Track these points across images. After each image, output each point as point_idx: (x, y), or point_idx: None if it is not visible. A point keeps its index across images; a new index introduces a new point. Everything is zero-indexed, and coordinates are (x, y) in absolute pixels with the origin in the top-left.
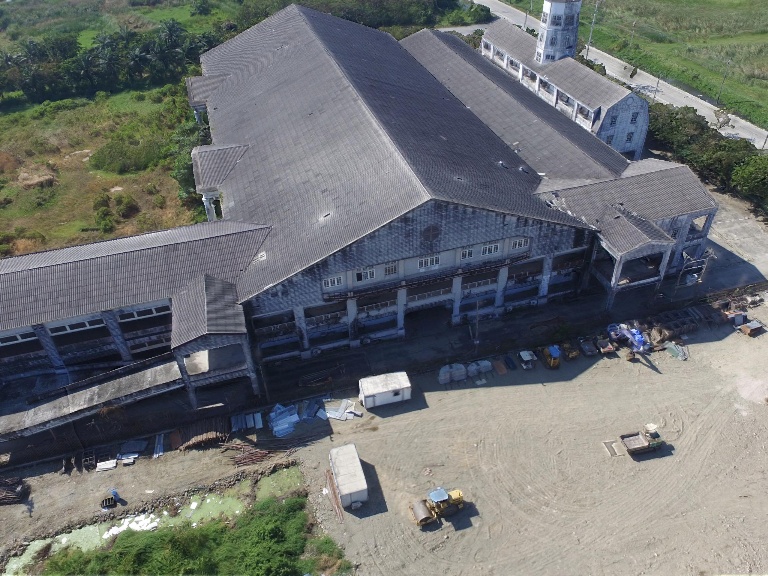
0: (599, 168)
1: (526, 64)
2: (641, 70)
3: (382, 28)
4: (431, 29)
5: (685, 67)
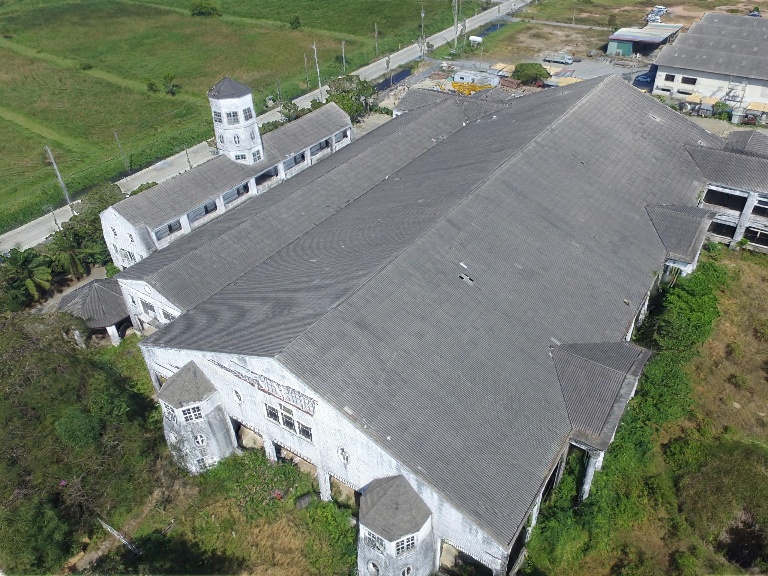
0: (449, 102)
1: (258, 172)
2: (38, 219)
3: (3, 442)
4: (139, 278)
5: (39, 191)
